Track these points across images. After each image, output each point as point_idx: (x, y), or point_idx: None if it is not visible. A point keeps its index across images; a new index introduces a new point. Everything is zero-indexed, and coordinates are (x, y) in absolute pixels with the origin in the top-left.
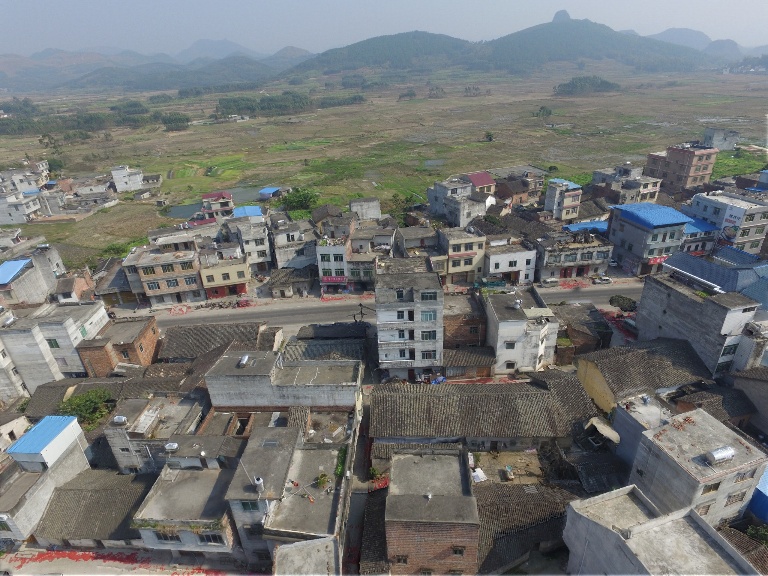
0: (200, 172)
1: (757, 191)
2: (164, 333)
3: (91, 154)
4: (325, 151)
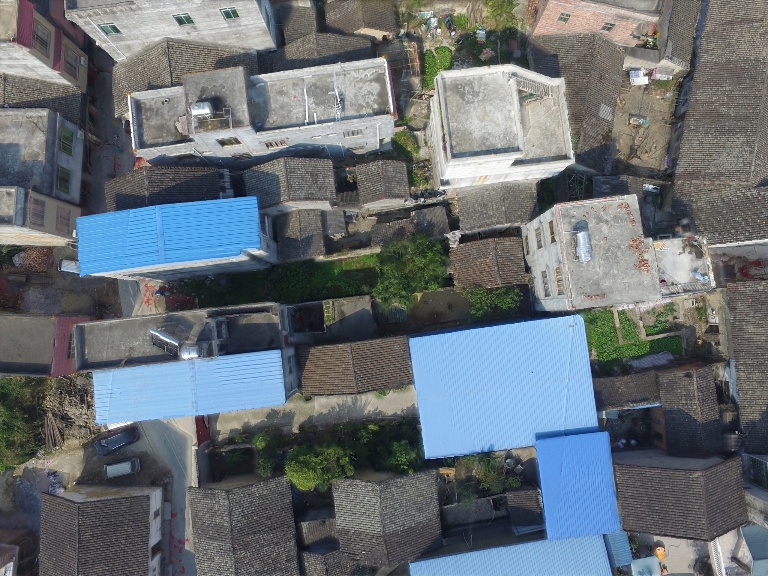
0: None
1: None
2: None
3: None
4: None
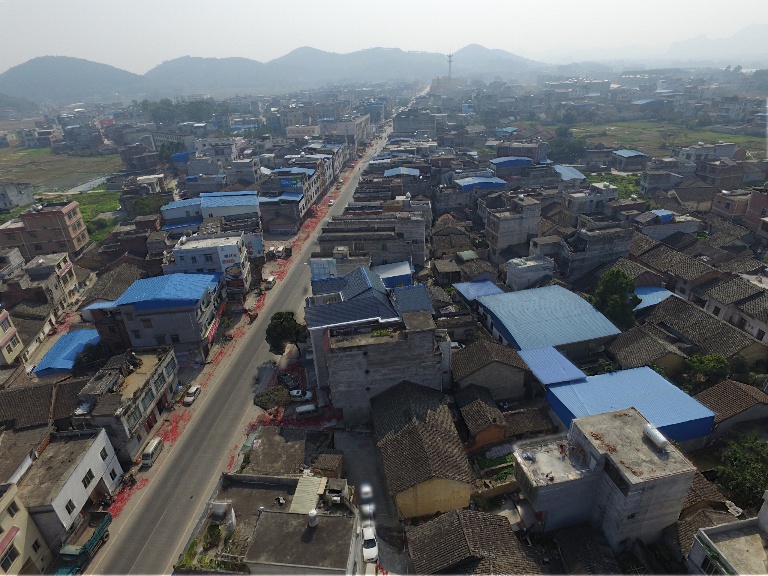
0: None
1: (175, 228)
2: None
3: None
4: None
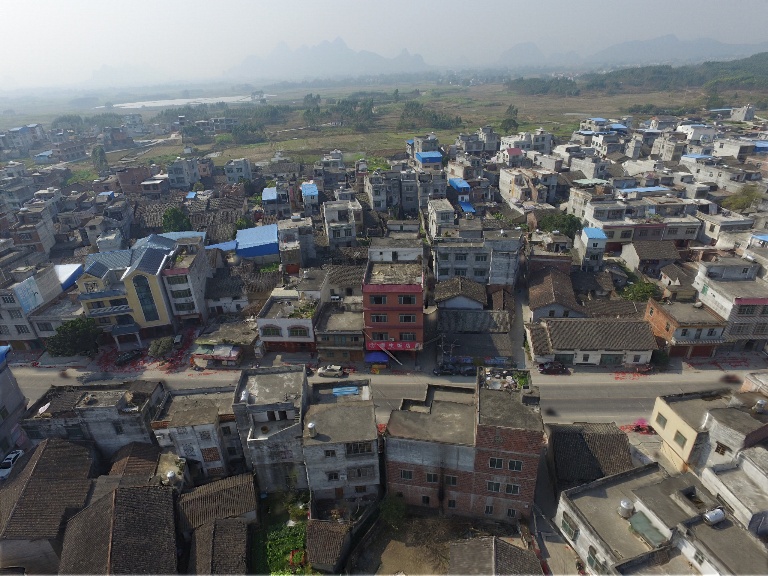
0: None
1: None
2: (705, 386)
3: None
4: None
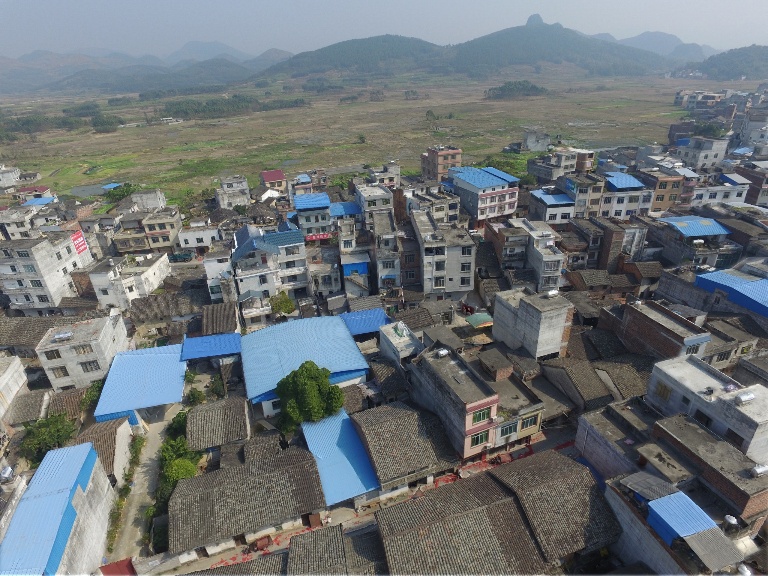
0: (82, 171)
1: None
2: None
3: (1, 154)
4: (212, 152)
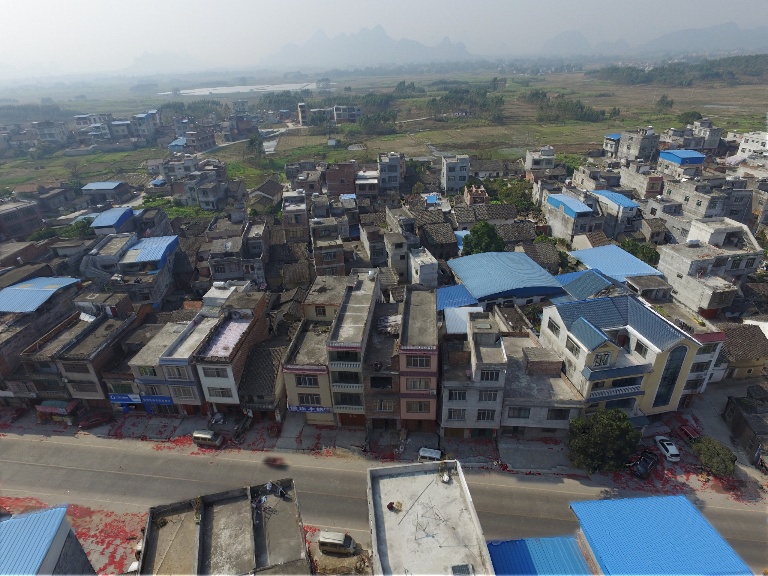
0: None
1: None
2: None
3: None
4: None
